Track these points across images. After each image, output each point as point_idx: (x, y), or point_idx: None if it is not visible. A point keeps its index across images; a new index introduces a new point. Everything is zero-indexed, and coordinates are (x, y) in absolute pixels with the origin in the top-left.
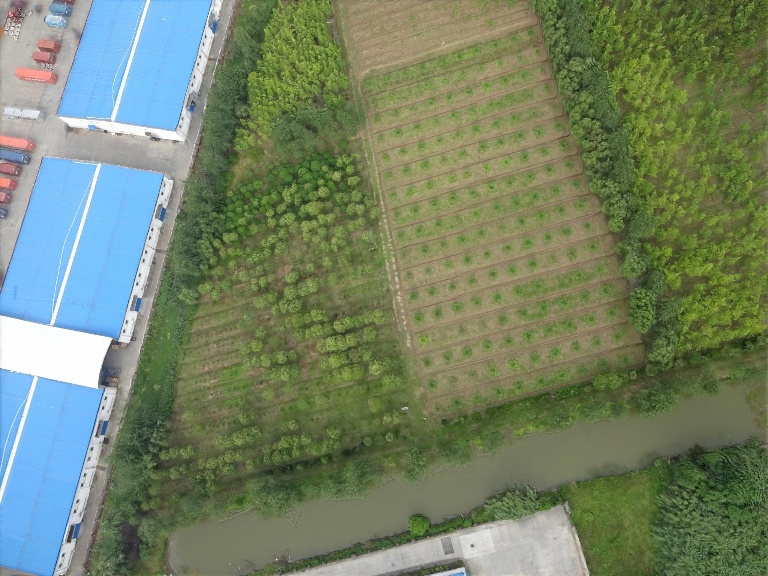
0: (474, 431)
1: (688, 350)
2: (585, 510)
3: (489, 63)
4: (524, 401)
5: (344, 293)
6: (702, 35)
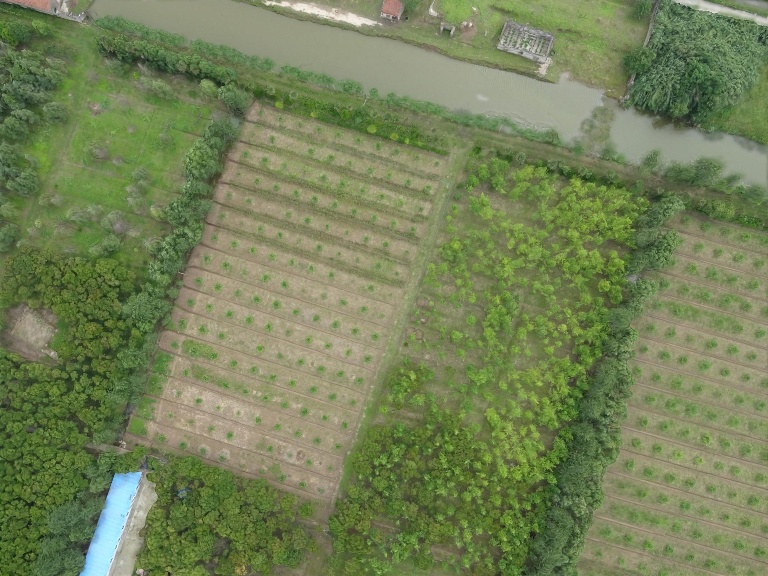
0: None
1: None
2: None
3: (629, 569)
4: None
5: None
6: (444, 461)
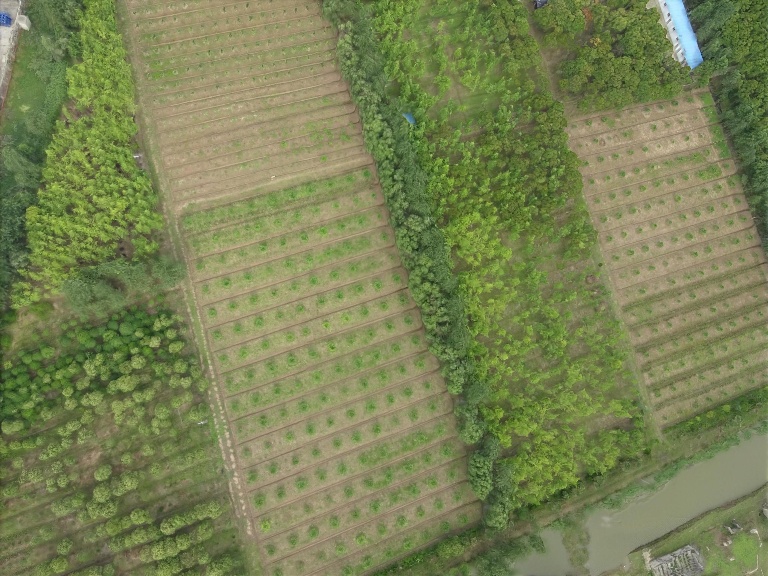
0: None
1: None
2: None
3: (324, 204)
4: None
5: (170, 480)
6: (524, 196)
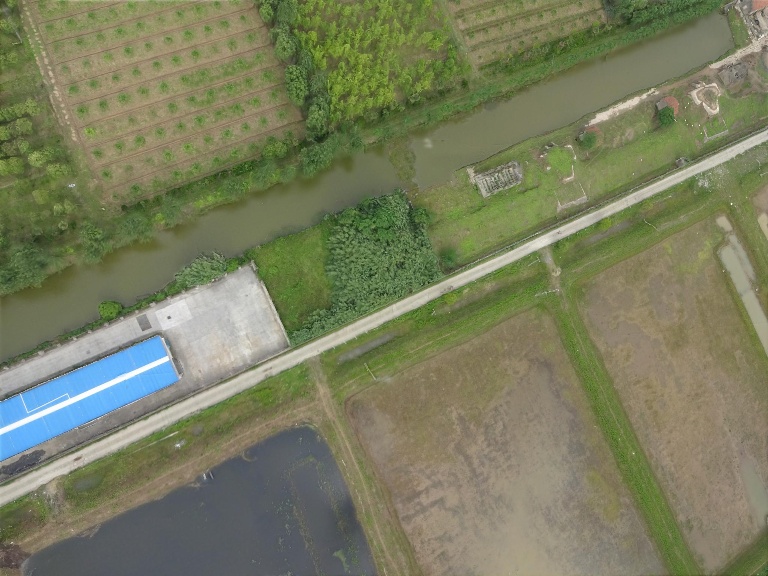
0: None
1: (339, 119)
2: (270, 265)
3: None
4: (203, 179)
5: None
6: None
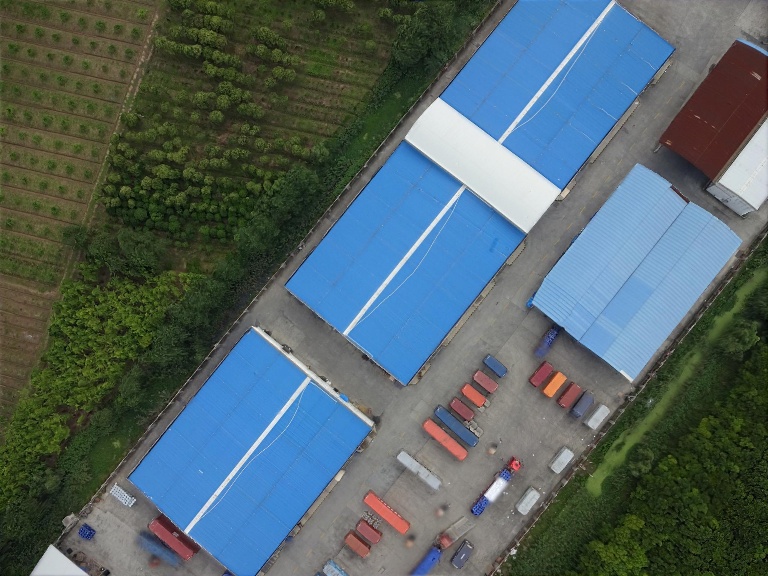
0: None
1: None
2: None
3: None
4: None
5: (185, 88)
6: None
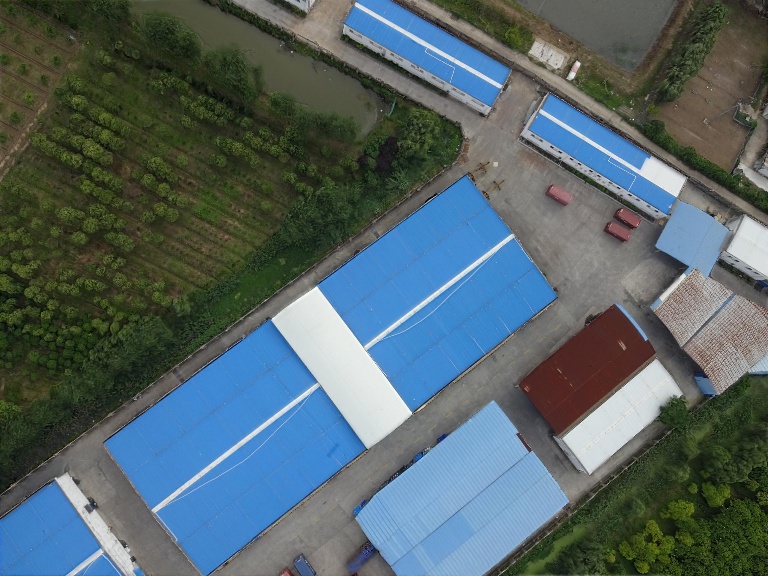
0: (60, 2)
1: None
2: None
3: None
4: None
5: (56, 193)
6: None
